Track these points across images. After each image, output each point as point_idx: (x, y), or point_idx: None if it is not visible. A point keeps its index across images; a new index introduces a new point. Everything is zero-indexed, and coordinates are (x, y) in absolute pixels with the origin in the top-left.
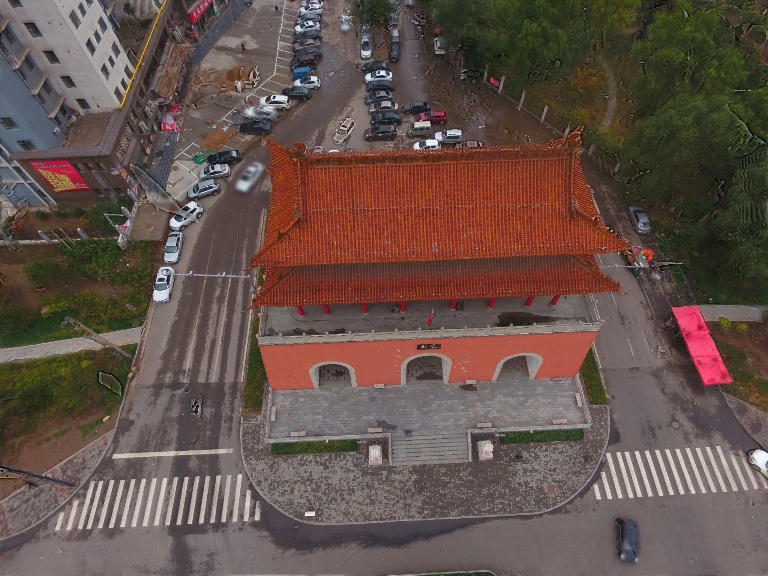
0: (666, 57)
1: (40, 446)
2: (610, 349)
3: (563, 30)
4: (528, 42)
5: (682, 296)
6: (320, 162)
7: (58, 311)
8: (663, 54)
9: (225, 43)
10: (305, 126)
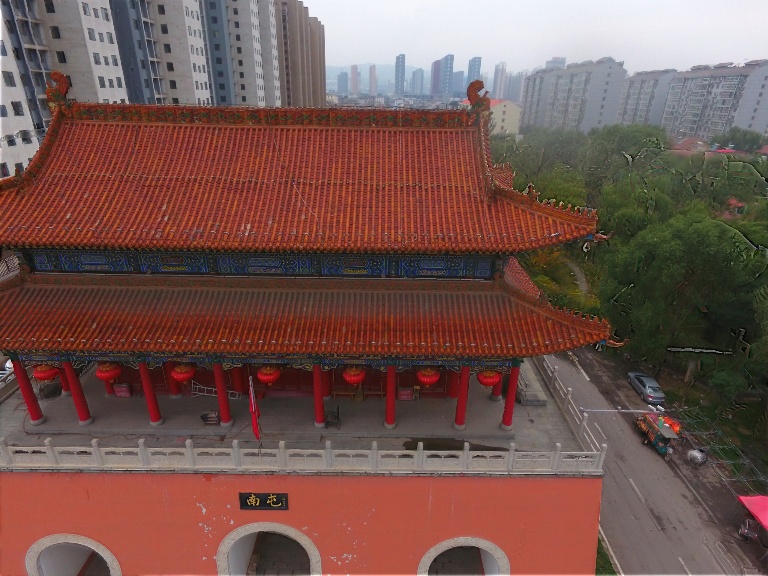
0: (625, 217)
1: None
2: (651, 575)
3: None
4: None
5: (749, 480)
6: (92, 114)
7: None
8: (621, 214)
9: None
10: None
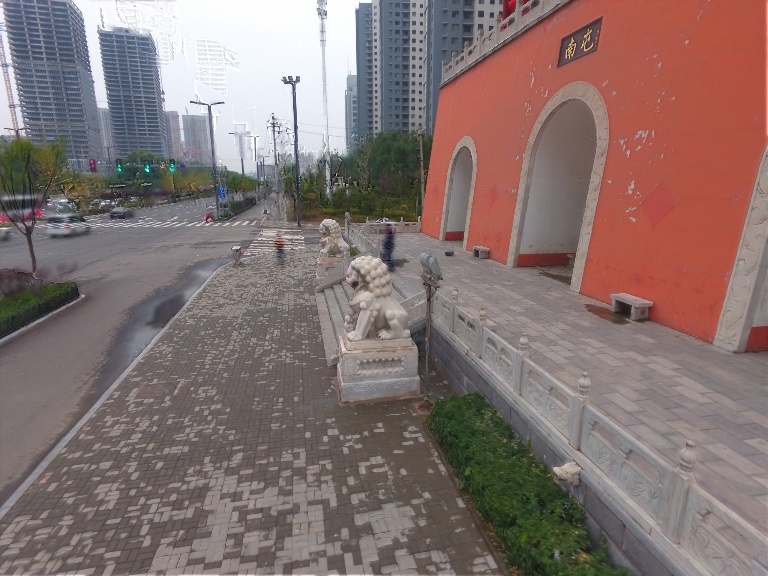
0: None
1: None
2: None
3: None
4: None
5: None
6: None
7: None
8: None
9: None
10: None
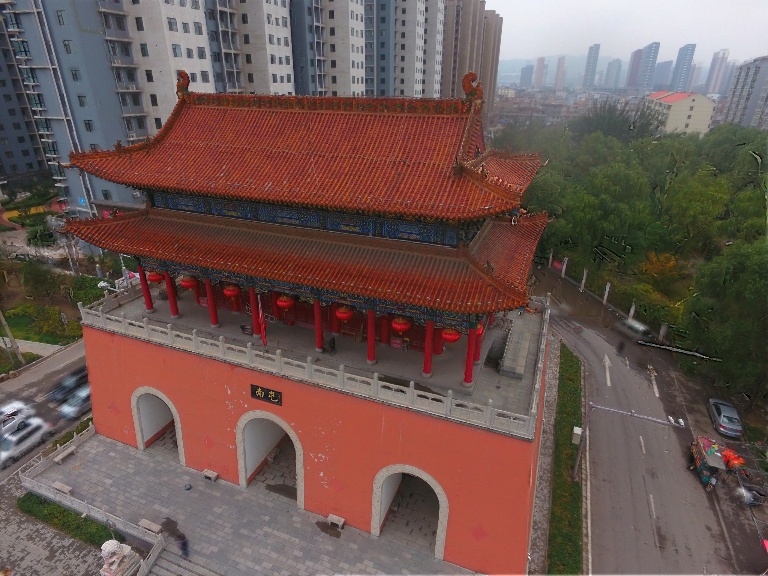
0: (755, 227)
1: None
2: None
3: (625, 203)
4: (586, 213)
5: None
6: (202, 101)
7: (20, 314)
8: (750, 224)
9: None
10: None
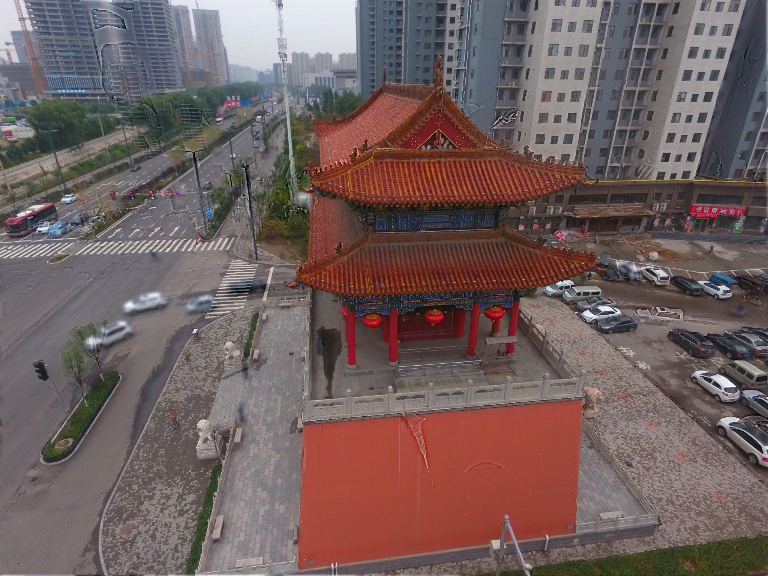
0: None
1: (284, 248)
2: None
3: None
4: None
5: None
6: None
7: None
8: None
9: (706, 245)
10: (644, 298)
